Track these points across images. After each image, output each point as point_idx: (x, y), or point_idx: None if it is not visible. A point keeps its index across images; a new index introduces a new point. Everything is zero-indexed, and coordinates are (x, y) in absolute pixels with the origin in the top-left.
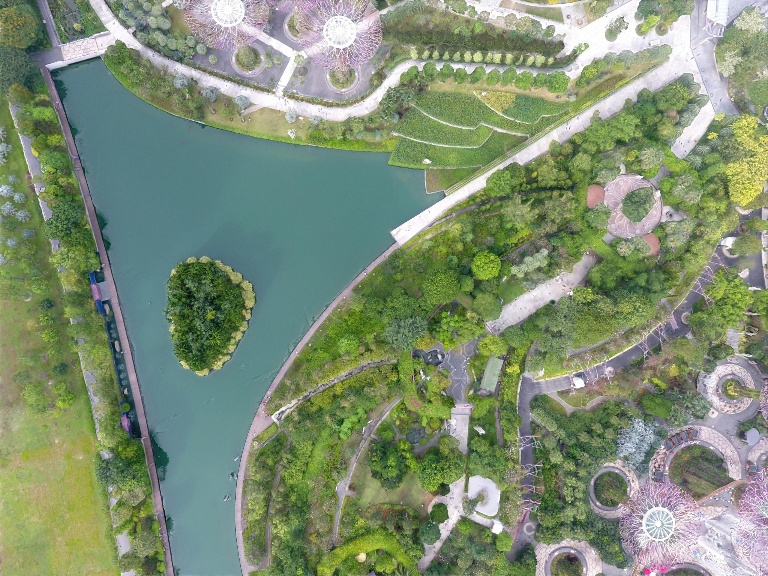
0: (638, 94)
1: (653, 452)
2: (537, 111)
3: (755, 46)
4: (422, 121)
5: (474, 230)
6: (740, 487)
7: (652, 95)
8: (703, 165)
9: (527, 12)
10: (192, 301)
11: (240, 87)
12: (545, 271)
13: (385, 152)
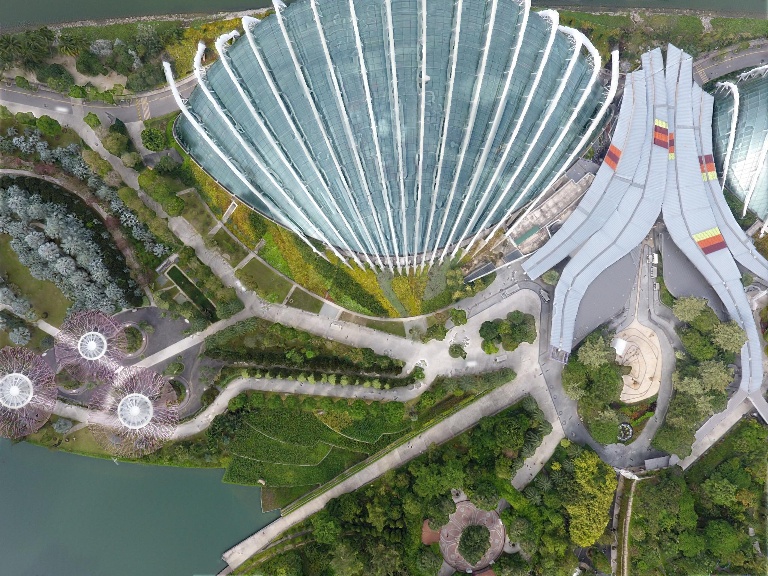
0: (479, 421)
1: None
2: (377, 430)
3: (597, 382)
4: (256, 439)
5: None
6: None
7: (492, 424)
8: (543, 502)
9: (368, 326)
10: None
11: (65, 404)
12: None
13: (219, 468)
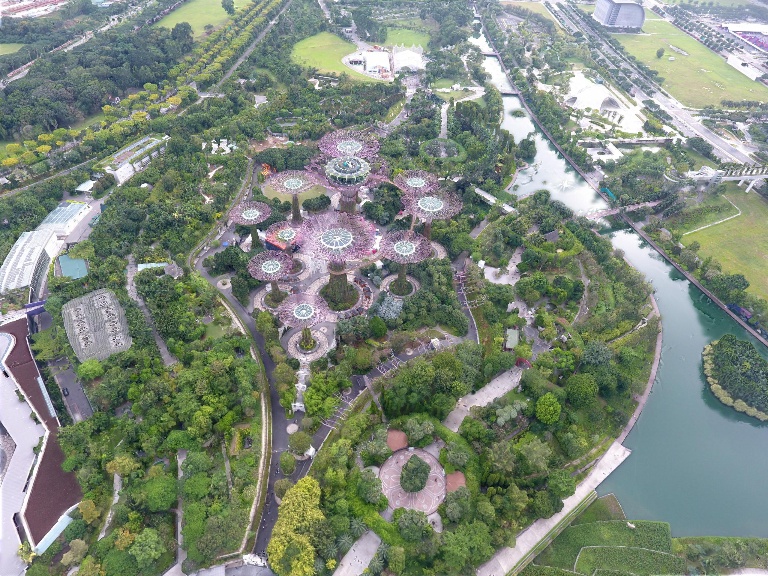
0: None
1: (379, 301)
2: None
3: None
4: (660, 575)
5: (558, 454)
6: (342, 269)
7: None
8: None
9: None
10: (766, 378)
11: None
12: (493, 409)
13: None
